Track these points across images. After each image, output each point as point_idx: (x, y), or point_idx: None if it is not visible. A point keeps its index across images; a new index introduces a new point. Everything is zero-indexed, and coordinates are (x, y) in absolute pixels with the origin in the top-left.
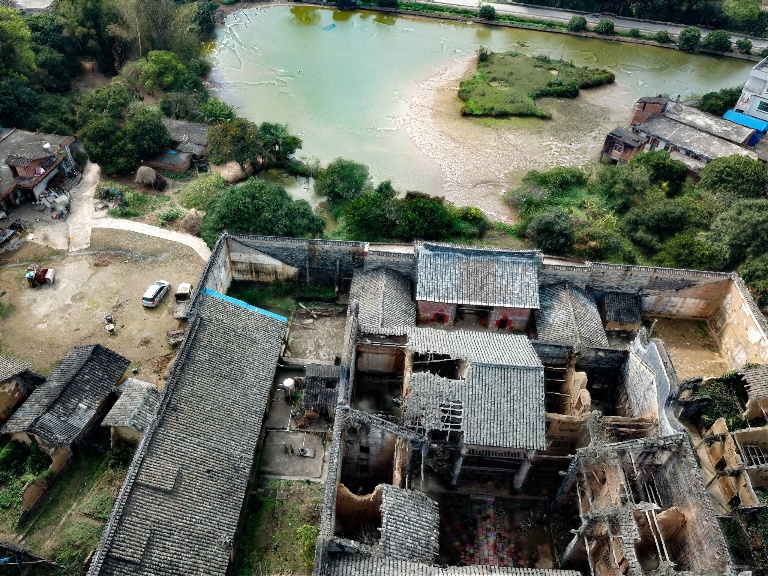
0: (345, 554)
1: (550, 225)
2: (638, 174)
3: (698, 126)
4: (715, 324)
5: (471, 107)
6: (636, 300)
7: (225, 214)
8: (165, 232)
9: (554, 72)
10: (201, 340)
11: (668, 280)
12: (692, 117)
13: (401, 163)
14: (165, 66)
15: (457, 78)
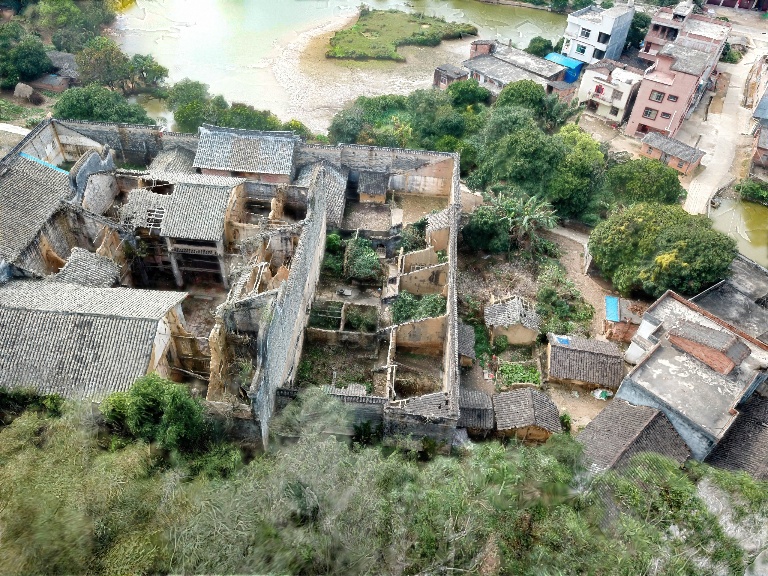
0: (26, 278)
1: (341, 127)
2: (439, 95)
3: (518, 64)
4: (449, 198)
5: (335, 51)
6: (385, 178)
7: (62, 109)
8: (25, 131)
9: (425, 26)
10: (3, 183)
11: (406, 160)
12: (517, 57)
13: (257, 92)
14: (59, 8)
15: (336, 30)
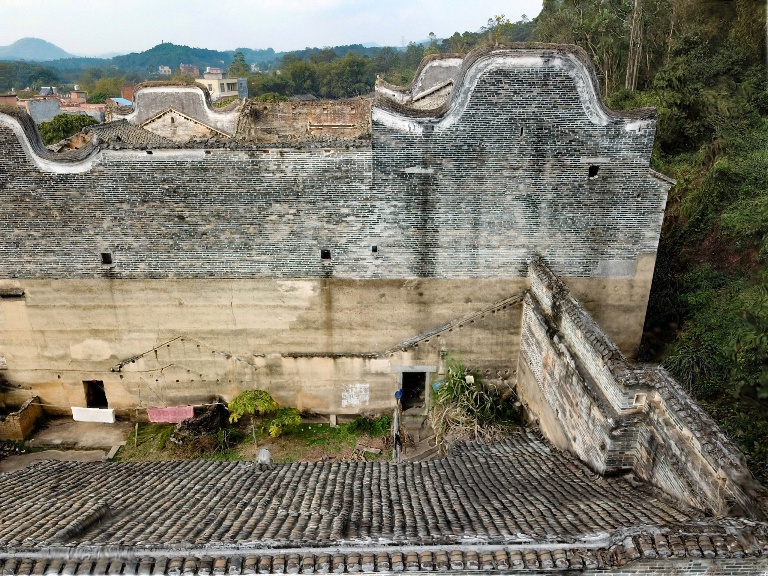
0: None
1: None
2: None
3: None
4: None
5: None
6: None
7: None
8: None
9: None
10: None
11: None
12: None
13: None
14: None
15: None
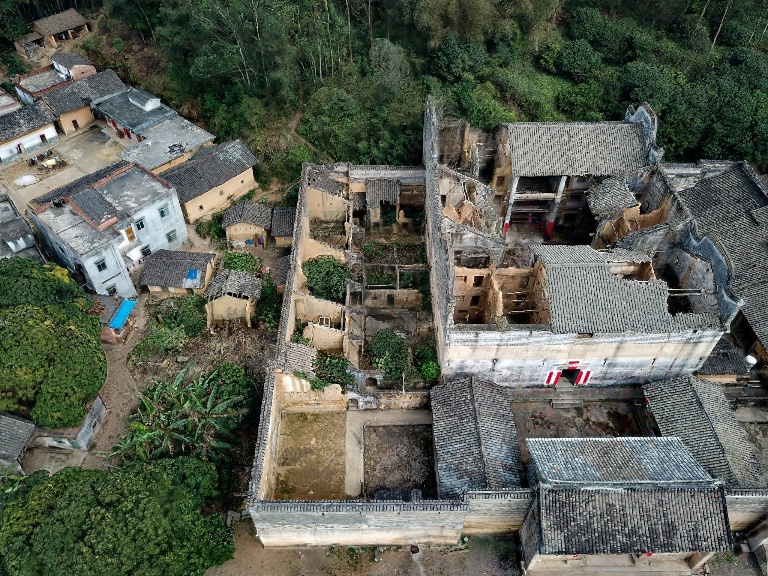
0: None
1: None
2: None
3: None
4: None
5: None
6: None
7: None
8: None
9: None
10: None
11: None
12: None
13: None
14: None
15: None
